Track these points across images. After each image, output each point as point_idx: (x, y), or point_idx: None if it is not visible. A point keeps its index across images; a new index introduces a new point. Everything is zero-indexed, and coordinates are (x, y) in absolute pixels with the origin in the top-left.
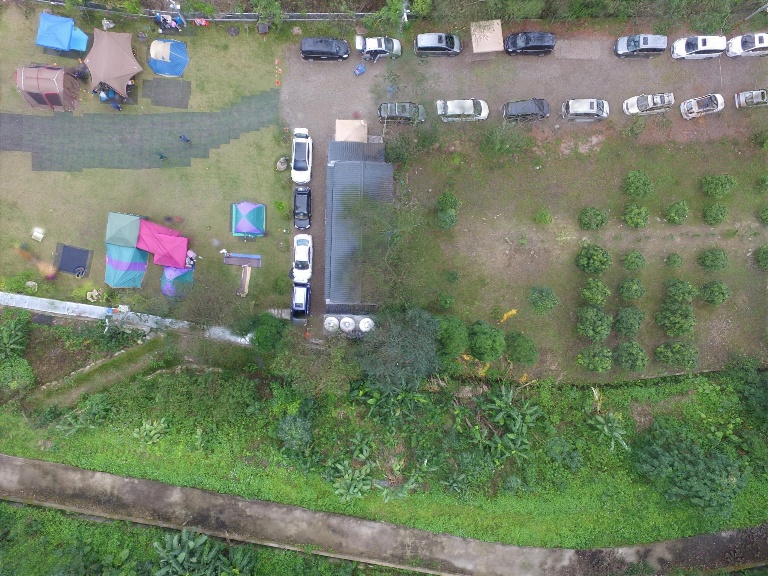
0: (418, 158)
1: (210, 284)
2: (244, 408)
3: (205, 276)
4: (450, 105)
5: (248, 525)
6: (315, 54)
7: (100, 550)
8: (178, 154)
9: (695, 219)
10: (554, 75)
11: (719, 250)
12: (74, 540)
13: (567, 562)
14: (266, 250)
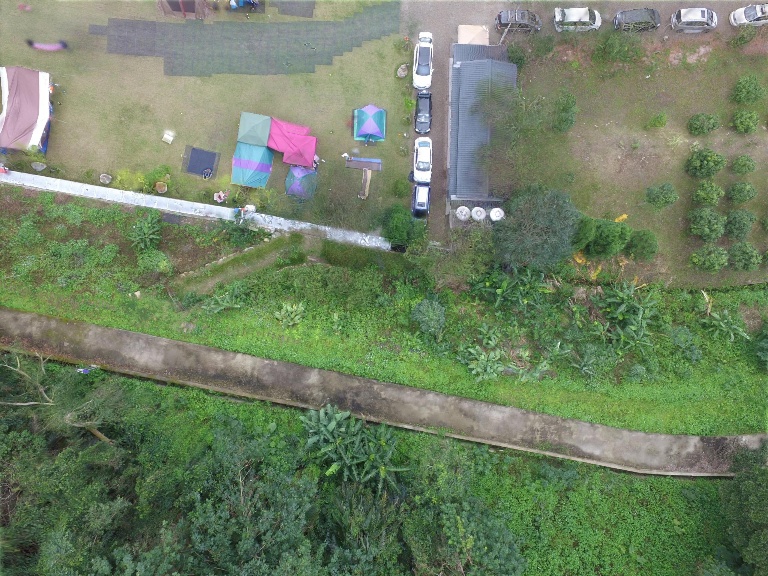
0: (532, 67)
1: (332, 187)
2: (373, 299)
3: (327, 179)
4: (567, 12)
5: (383, 408)
6: None
7: (246, 424)
8: (303, 61)
9: None
10: None
11: None
12: (221, 415)
13: (692, 449)
14: (386, 154)
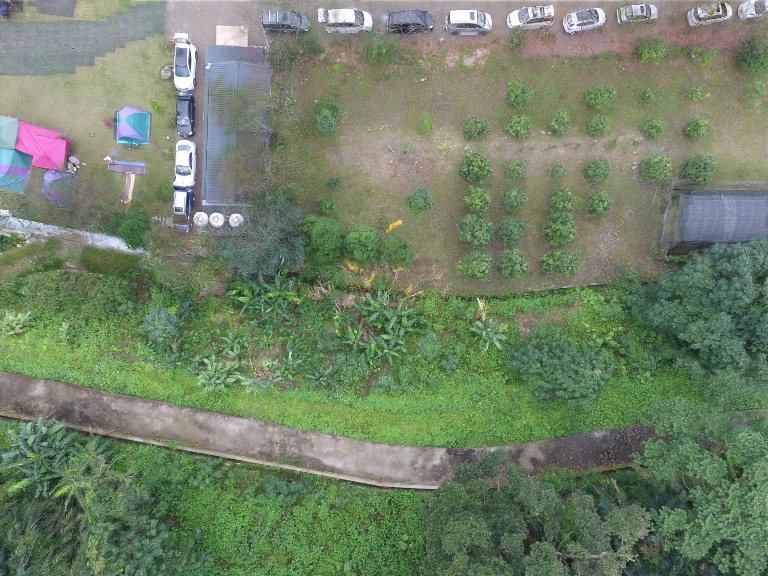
0: (304, 69)
1: (94, 191)
2: (117, 307)
3: (89, 183)
4: (331, 13)
5: (113, 420)
6: None
7: None
8: (63, 61)
9: (579, 132)
10: None
11: (601, 160)
12: None
13: (438, 461)
14: (150, 158)
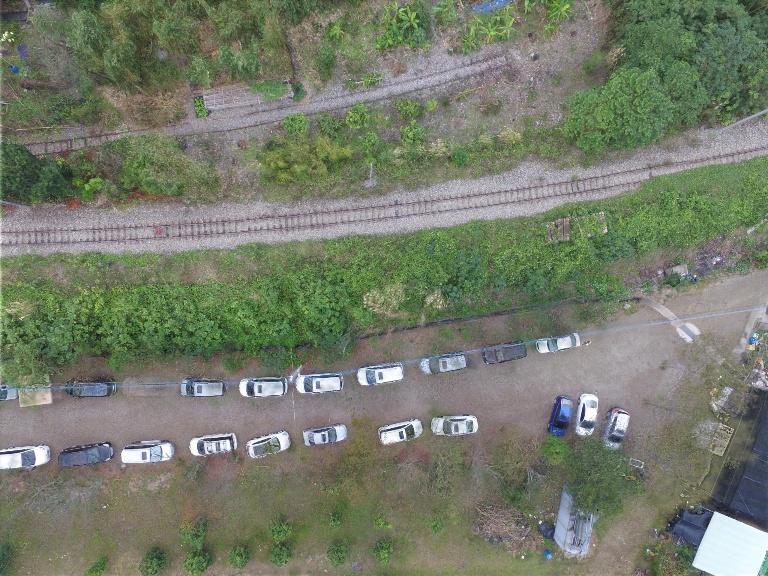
0: None
1: None
2: None
3: None
4: None
5: None
6: None
7: None
8: None
9: (268, 553)
10: (122, 413)
11: None
12: None
13: None
14: None
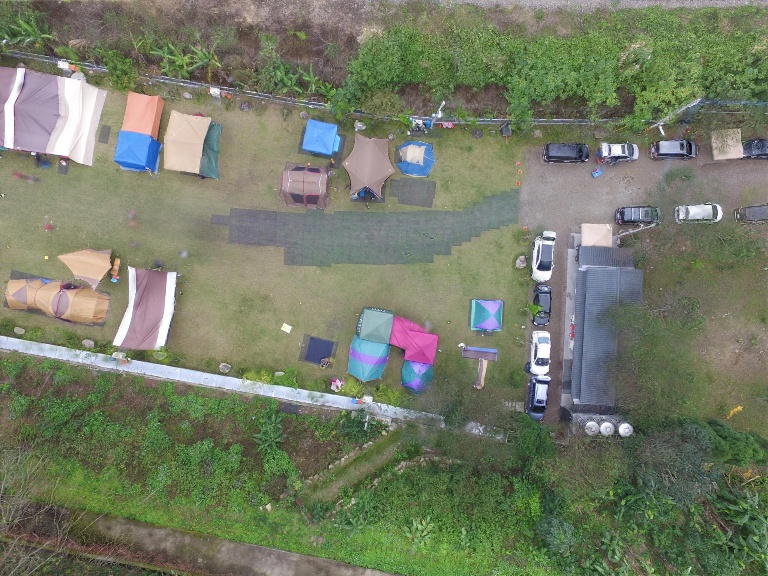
0: (650, 257)
1: (447, 376)
2: (496, 505)
3: (443, 368)
4: (691, 210)
5: None
6: (560, 159)
7: None
8: (422, 251)
9: None
10: None
11: None
12: None
13: None
14: (502, 344)
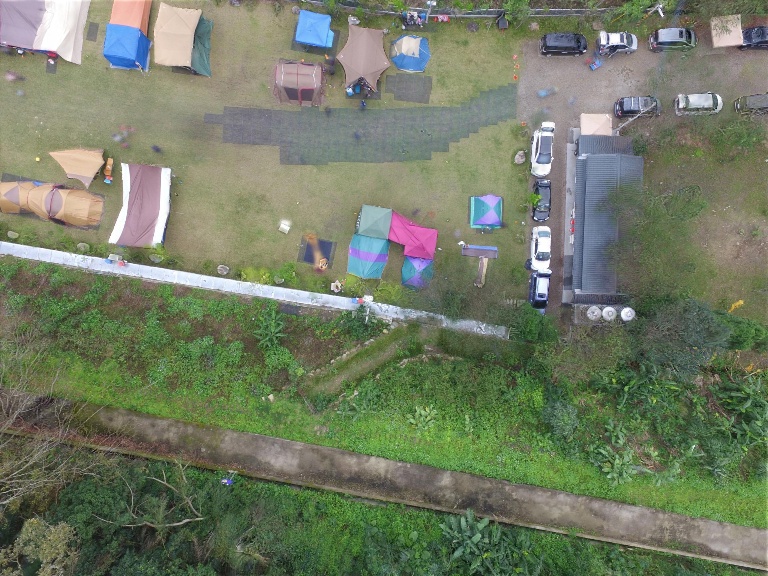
0: (649, 151)
1: (448, 275)
2: (499, 395)
3: (443, 267)
4: (691, 99)
5: (514, 508)
6: (558, 49)
7: (386, 531)
8: (419, 148)
9: None
10: None
11: None
12: (360, 521)
13: None
14: (502, 242)
